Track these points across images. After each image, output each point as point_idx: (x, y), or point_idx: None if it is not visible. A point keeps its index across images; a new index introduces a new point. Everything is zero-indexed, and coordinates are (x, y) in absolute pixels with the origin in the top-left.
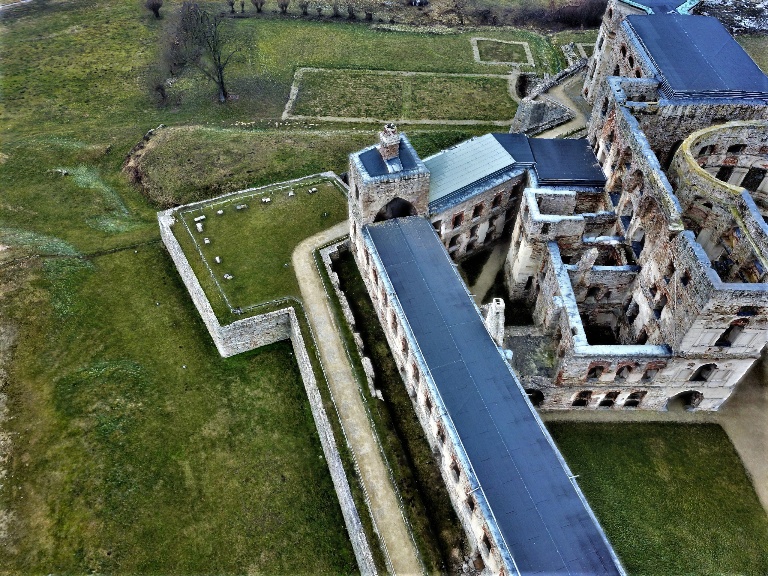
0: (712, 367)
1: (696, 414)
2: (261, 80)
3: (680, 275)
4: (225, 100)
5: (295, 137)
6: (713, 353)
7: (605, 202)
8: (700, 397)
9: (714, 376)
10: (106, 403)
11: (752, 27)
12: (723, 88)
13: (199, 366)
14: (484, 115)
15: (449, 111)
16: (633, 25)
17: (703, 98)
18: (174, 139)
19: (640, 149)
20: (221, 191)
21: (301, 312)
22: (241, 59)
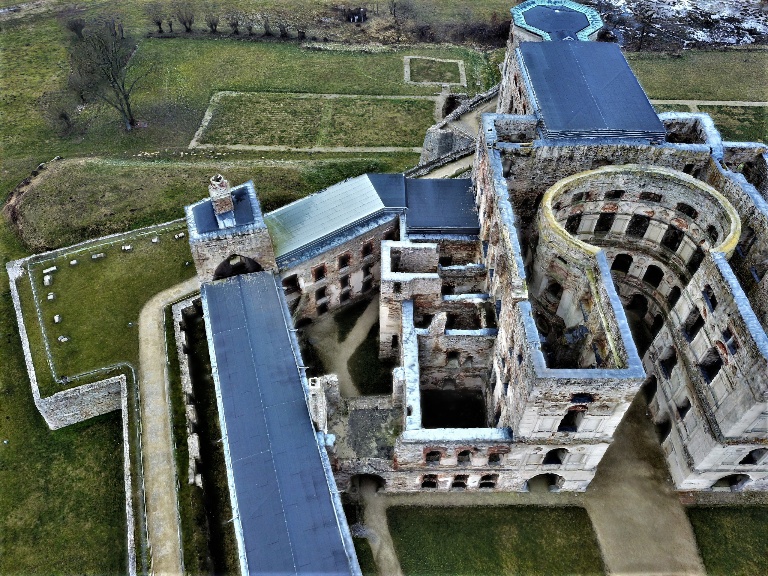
0: (565, 450)
1: (561, 496)
2: (174, 106)
3: (516, 352)
4: (132, 128)
5: (191, 170)
6: (559, 438)
7: (480, 251)
8: (562, 478)
9: (570, 459)
10: None
11: (701, 41)
12: (602, 127)
13: (22, 440)
14: (404, 141)
15: (367, 137)
16: (523, 53)
17: (580, 138)
18: (61, 174)
19: (498, 200)
20: (99, 232)
21: (133, 380)
22: (158, 83)
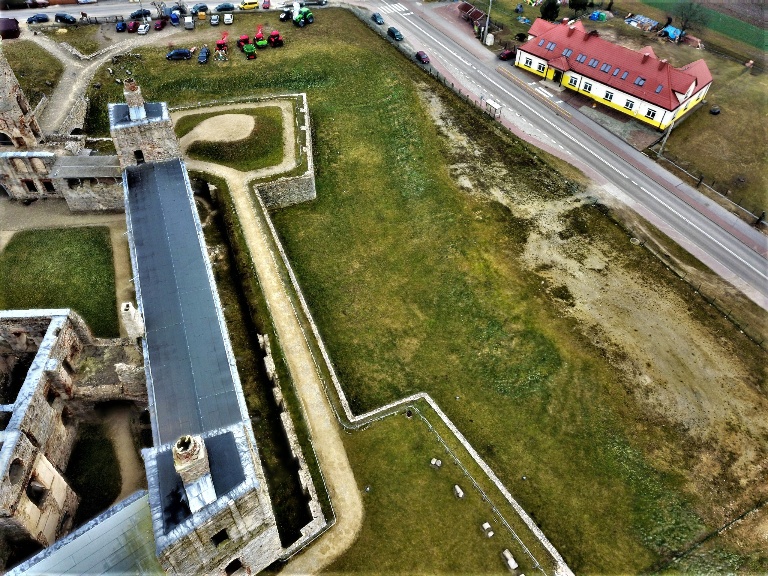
0: None
1: None
2: None
3: None
4: None
5: None
6: None
7: None
8: None
9: None
10: (507, 347)
11: None
12: None
13: (444, 400)
14: None
15: None
16: None
17: None
18: None
19: None
20: None
21: None
22: None
